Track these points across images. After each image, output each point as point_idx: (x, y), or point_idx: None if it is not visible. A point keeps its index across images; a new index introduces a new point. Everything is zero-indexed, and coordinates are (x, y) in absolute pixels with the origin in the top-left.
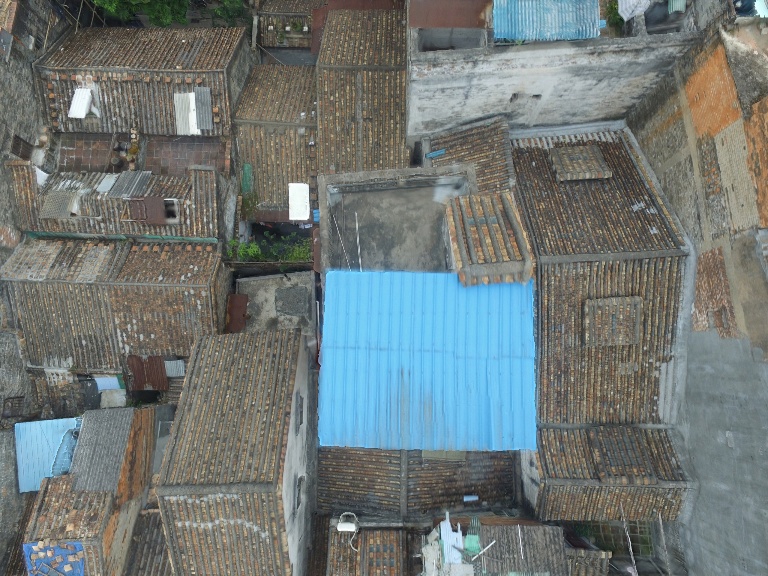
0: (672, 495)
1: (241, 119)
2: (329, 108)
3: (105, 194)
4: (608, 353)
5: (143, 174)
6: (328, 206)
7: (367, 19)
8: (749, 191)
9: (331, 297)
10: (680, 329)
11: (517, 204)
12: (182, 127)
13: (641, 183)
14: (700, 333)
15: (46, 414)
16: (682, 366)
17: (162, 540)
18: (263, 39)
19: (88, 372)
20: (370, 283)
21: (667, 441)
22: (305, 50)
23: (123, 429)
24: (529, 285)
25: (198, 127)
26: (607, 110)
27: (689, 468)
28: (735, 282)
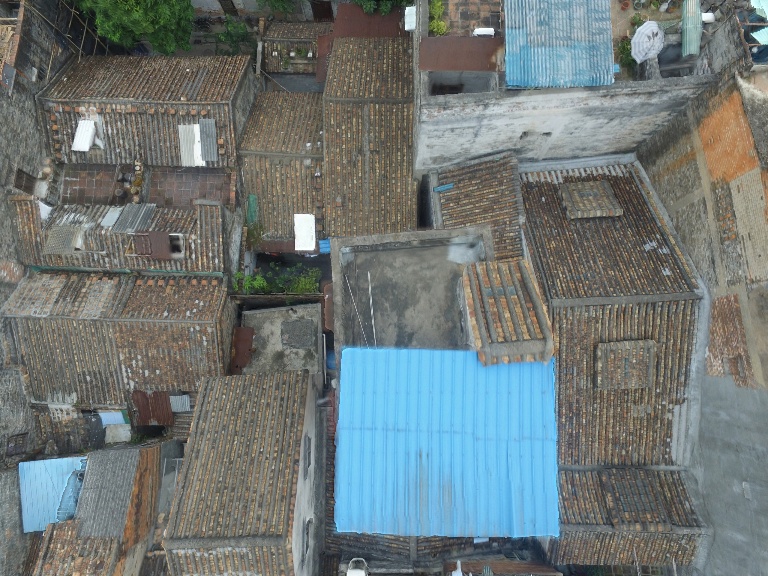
0: (686, 541)
1: (246, 150)
2: (335, 140)
3: (109, 229)
4: (620, 395)
5: (147, 207)
6: (340, 266)
7: (373, 48)
8: (767, 242)
9: (347, 376)
10: (693, 372)
11: (527, 243)
12: (187, 159)
13: (653, 220)
14: (715, 378)
15: (50, 450)
16: (695, 409)
17: None
18: (267, 65)
19: (92, 408)
20: (387, 361)
21: (680, 484)
22: (310, 75)
23: (129, 471)
24: (550, 363)
25: (203, 159)
26: (617, 145)
27: (703, 513)
28: (752, 332)
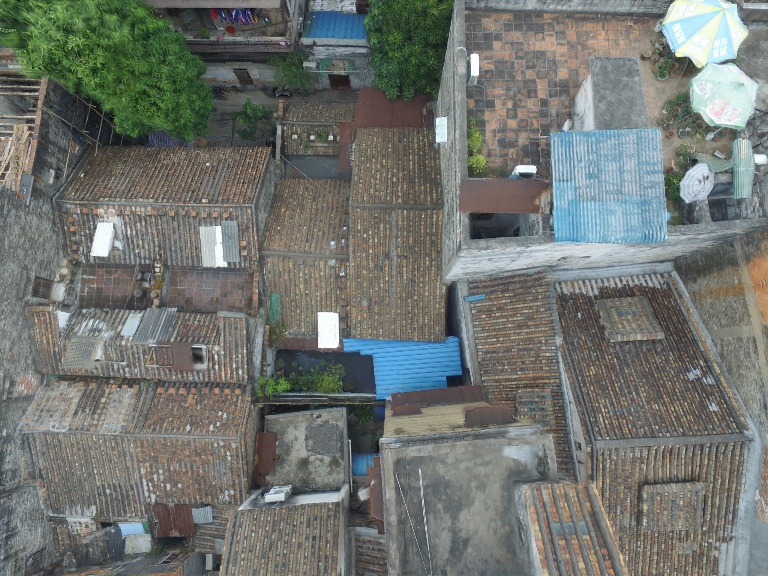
0: None
1: (269, 250)
2: (362, 245)
3: (130, 339)
4: (665, 533)
5: (168, 312)
6: None
7: (398, 141)
8: None
9: None
10: (742, 511)
11: (566, 369)
12: (208, 259)
13: (694, 343)
14: (766, 525)
15: (68, 562)
16: (744, 548)
17: None
18: (287, 147)
19: (112, 521)
20: None
21: None
22: (330, 157)
23: None
24: None
25: (224, 260)
26: (655, 259)
27: None
28: None
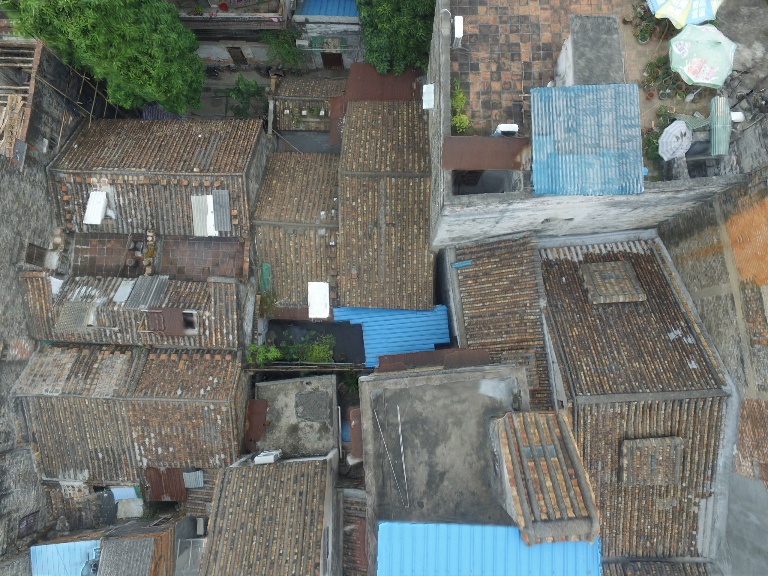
0: None
1: (260, 220)
2: (351, 213)
3: (122, 304)
4: (645, 489)
5: (160, 279)
6: None
7: (387, 113)
8: None
9: (384, 552)
10: (720, 466)
11: (549, 330)
12: (199, 229)
13: (676, 305)
14: (743, 478)
15: (61, 526)
16: (722, 503)
17: None
18: (279, 123)
19: (104, 485)
20: (426, 537)
21: None
22: (321, 132)
23: (144, 563)
24: (595, 541)
25: (216, 229)
26: (639, 224)
27: None
28: None
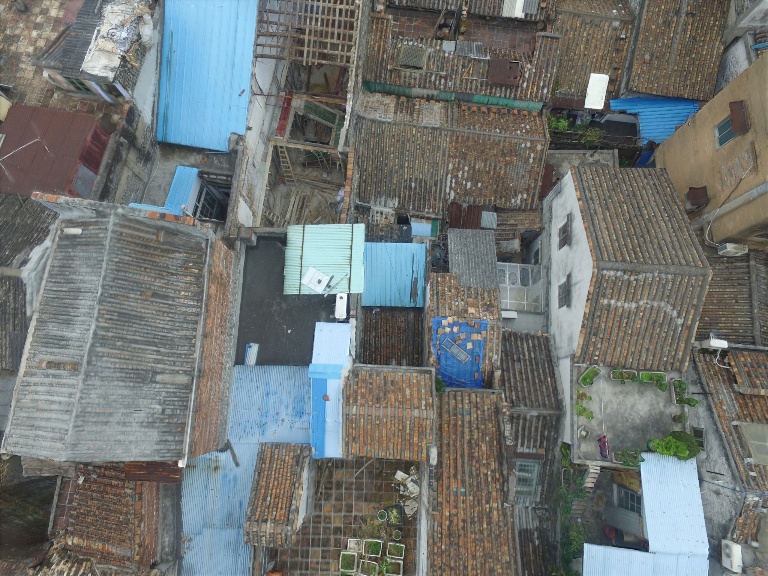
0: None
1: (562, 8)
2: (657, 1)
3: (452, 53)
4: None
5: (476, 44)
6: None
7: None
8: None
9: None
10: None
11: None
12: (508, 9)
13: None
14: None
15: None
16: None
17: (516, 351)
18: None
19: (411, 214)
20: None
21: None
22: None
23: (490, 245)
24: None
25: (523, 11)
26: None
27: None
28: None
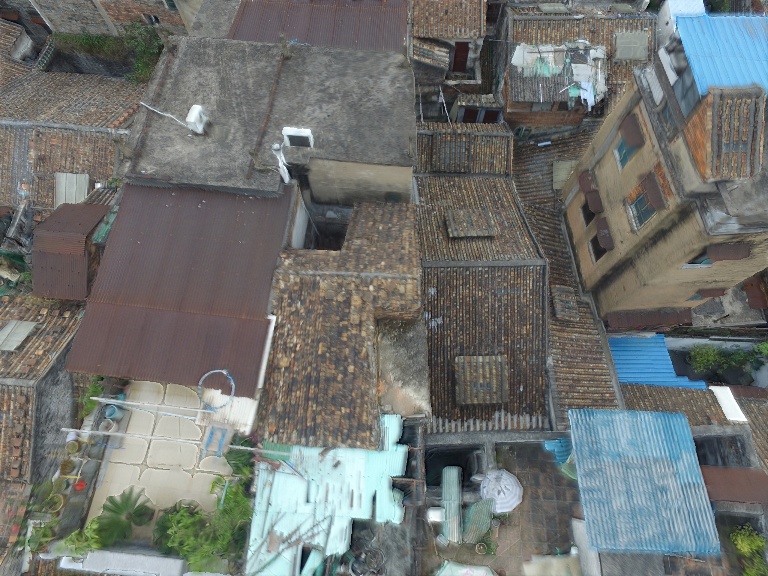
0: None
1: None
2: None
3: None
4: None
5: None
6: None
7: None
8: None
9: None
10: None
11: None
12: None
13: None
14: None
15: None
16: None
17: None
18: None
19: None
20: None
21: None
22: None
23: None
24: None
25: None
26: None
27: None
28: None
